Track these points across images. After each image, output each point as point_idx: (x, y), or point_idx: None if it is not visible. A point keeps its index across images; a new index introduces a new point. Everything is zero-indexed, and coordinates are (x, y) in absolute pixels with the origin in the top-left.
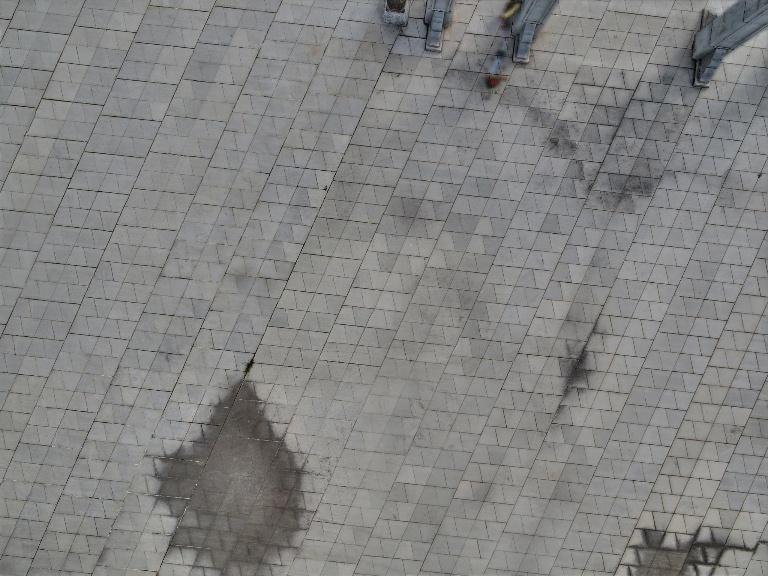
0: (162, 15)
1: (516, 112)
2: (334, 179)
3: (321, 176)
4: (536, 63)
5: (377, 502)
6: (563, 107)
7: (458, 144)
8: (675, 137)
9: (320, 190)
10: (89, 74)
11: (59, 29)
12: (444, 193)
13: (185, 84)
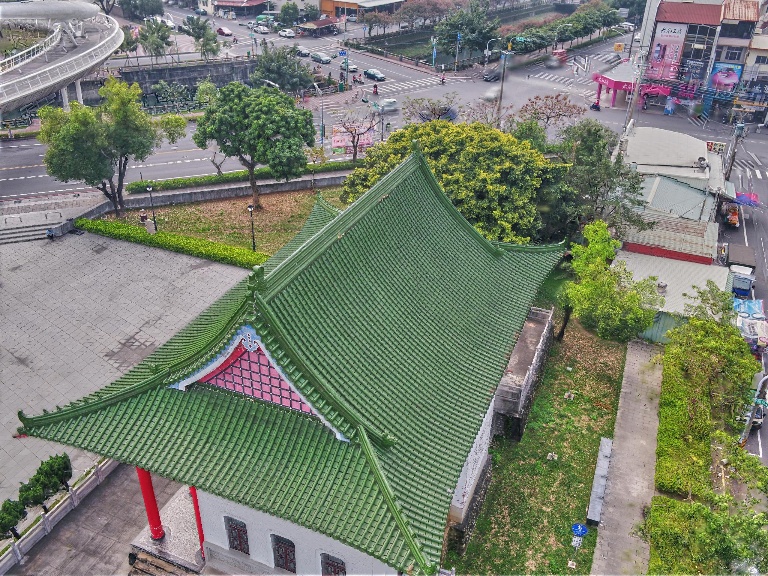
0: None
1: None
2: None
3: None
4: None
5: (5, 433)
6: None
7: None
8: None
9: None
10: None
11: None
12: None
13: None
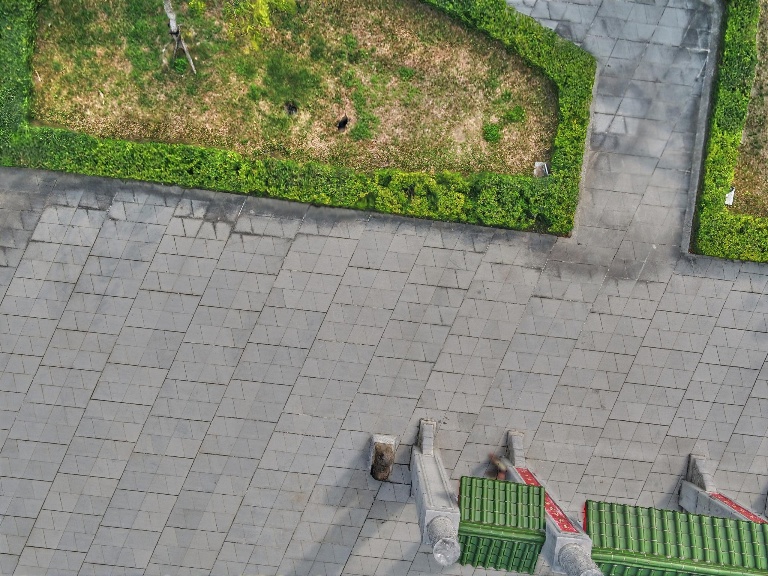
0: (146, 462)
1: None
2: None
3: None
4: None
5: None
6: None
7: None
8: None
9: None
10: (72, 521)
11: (42, 476)
12: None
13: (169, 531)
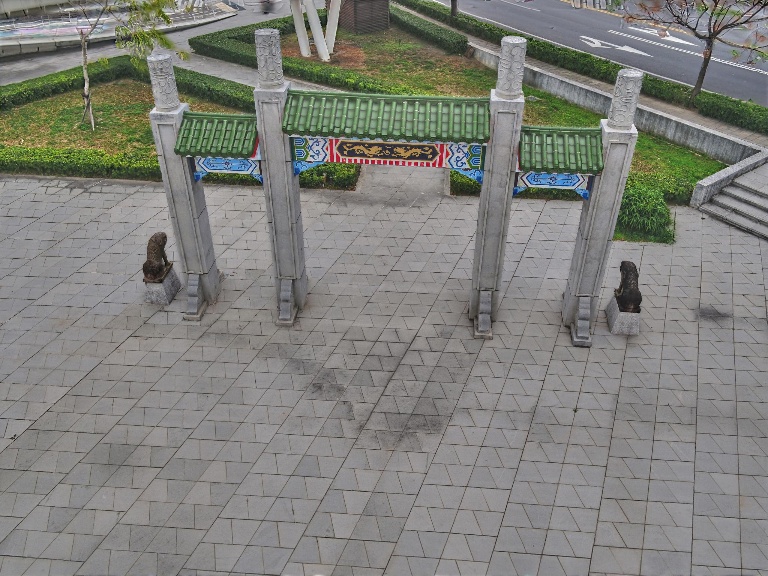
0: None
1: (275, 363)
2: (30, 428)
3: (14, 425)
4: (302, 326)
5: None
6: (330, 358)
7: (200, 391)
8: (462, 379)
9: (5, 439)
10: None
11: None
12: (169, 438)
13: None
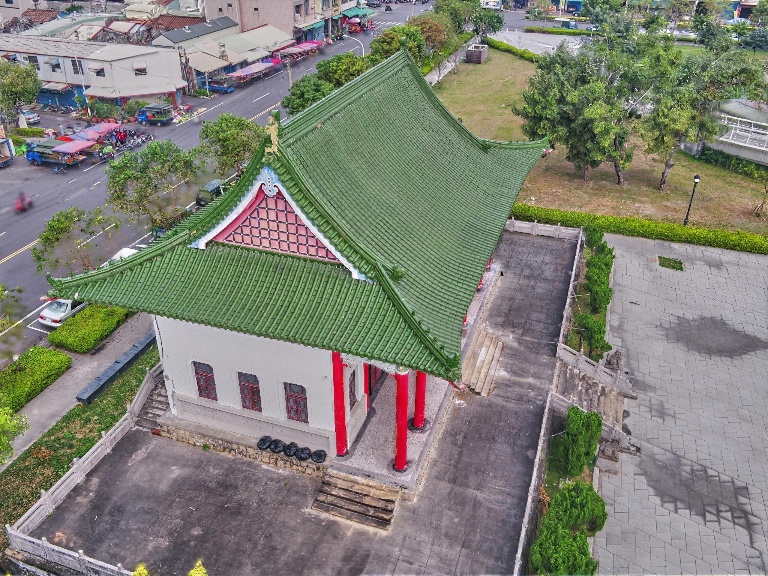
0: None
1: None
2: None
3: None
4: None
5: None
6: None
7: None
8: None
9: None
10: None
11: None
12: None
13: None
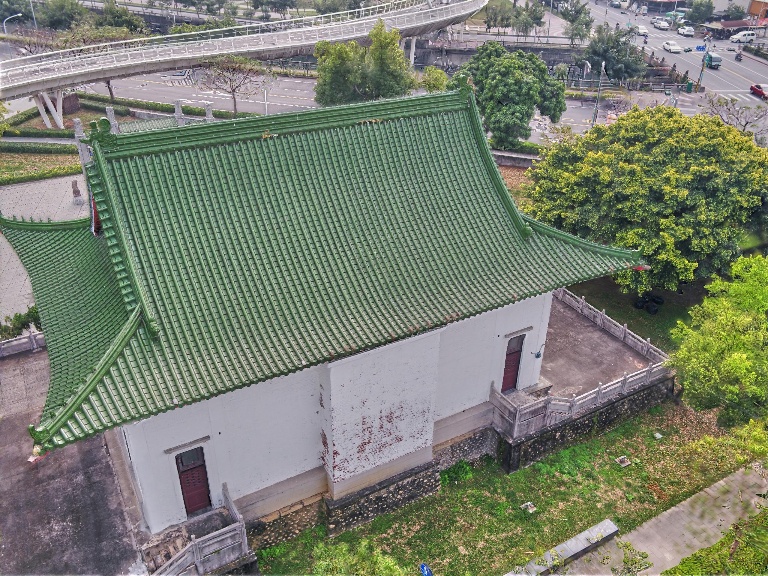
0: None
1: None
2: None
3: None
4: None
5: None
6: None
7: None
8: None
9: None
10: None
11: None
12: None
13: None
